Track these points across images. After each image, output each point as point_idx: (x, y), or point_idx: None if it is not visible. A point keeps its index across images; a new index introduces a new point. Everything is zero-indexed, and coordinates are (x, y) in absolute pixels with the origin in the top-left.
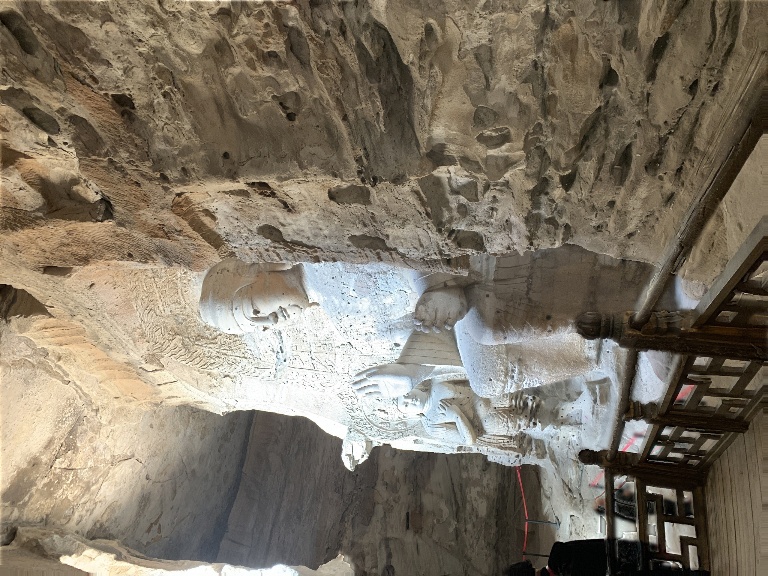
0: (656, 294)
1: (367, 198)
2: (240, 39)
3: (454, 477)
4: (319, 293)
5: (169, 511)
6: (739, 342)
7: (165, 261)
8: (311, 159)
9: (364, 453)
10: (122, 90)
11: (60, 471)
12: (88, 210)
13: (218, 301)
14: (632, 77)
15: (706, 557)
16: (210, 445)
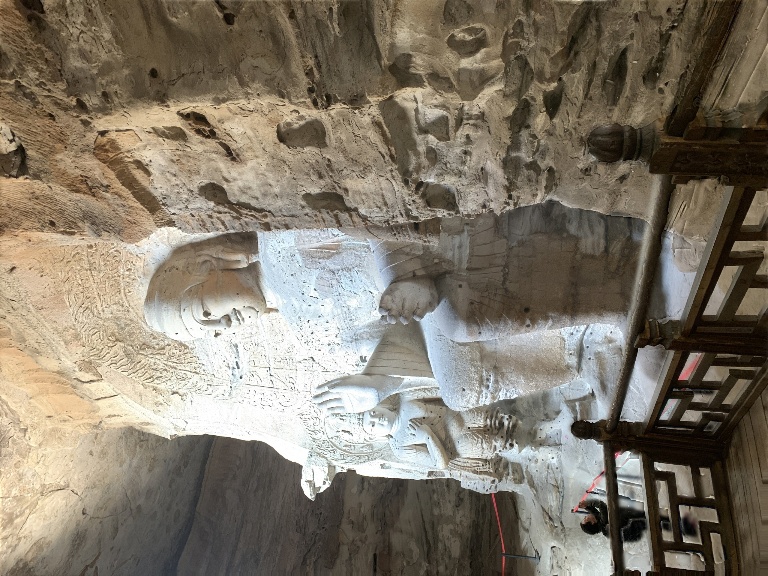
0: (717, 35)
1: (322, 140)
2: None
3: (425, 514)
4: (277, 295)
5: (108, 552)
6: None
7: (93, 230)
8: (253, 73)
9: (326, 479)
10: None
11: None
12: (0, 163)
13: (164, 301)
14: None
15: (733, 546)
16: (159, 479)
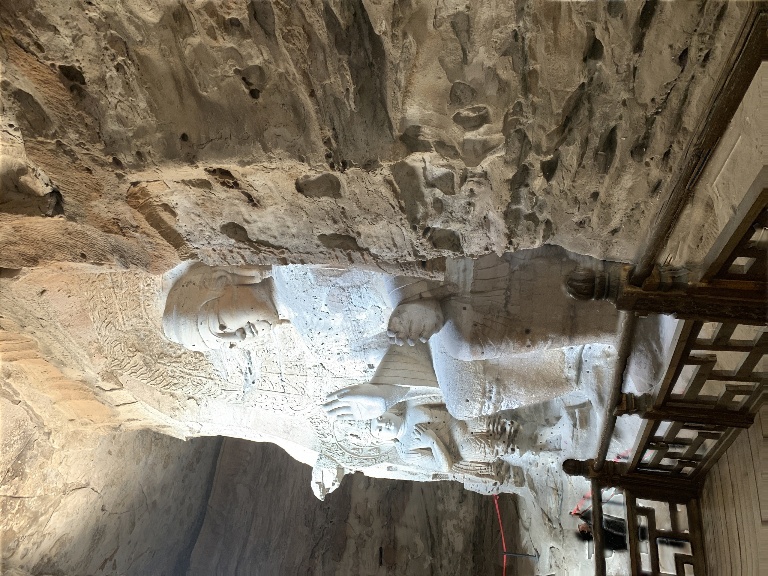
0: (662, 231)
1: (337, 191)
2: (199, 3)
3: (429, 509)
4: (290, 308)
5: (126, 545)
6: (755, 299)
7: (121, 262)
8: (276, 141)
9: (335, 481)
10: (71, 61)
11: (5, 499)
12: (37, 204)
13: (182, 315)
14: (618, 47)
15: None
16: (173, 475)
